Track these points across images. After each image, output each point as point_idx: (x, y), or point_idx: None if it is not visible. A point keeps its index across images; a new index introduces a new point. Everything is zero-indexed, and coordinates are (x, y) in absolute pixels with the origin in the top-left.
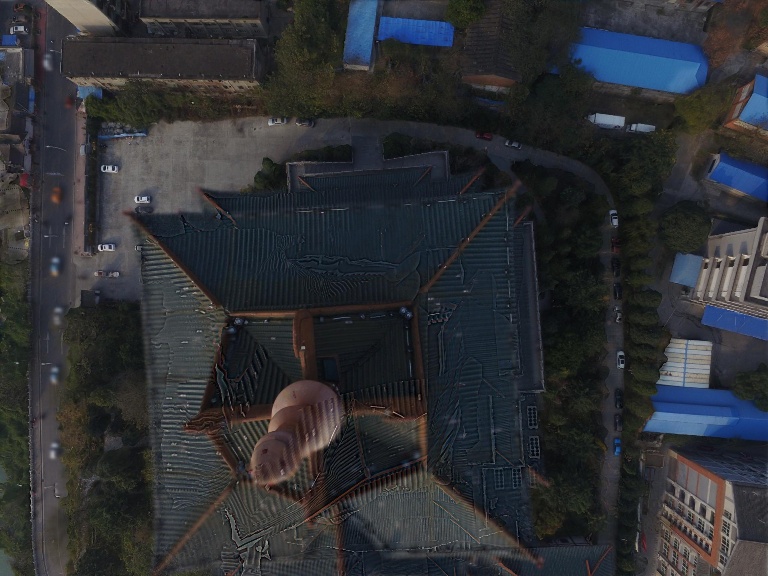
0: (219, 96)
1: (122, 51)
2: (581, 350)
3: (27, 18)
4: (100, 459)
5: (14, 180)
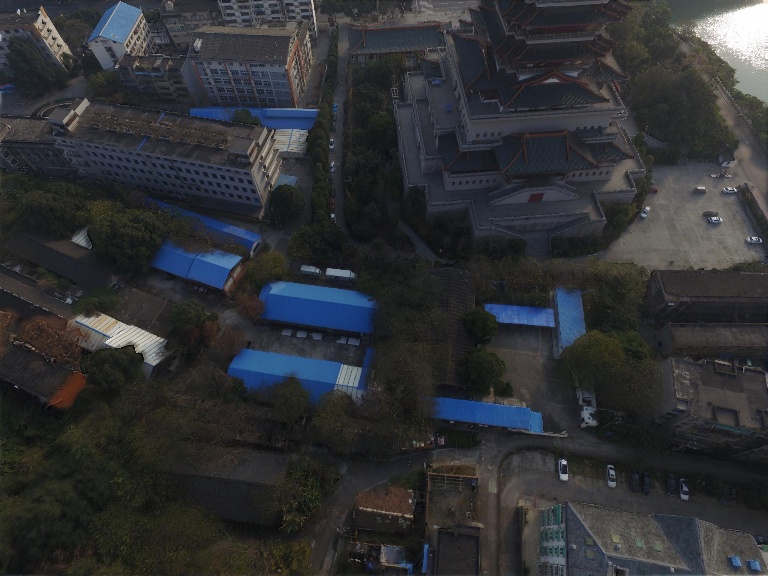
0: None
1: None
2: (372, 121)
3: None
4: None
5: None
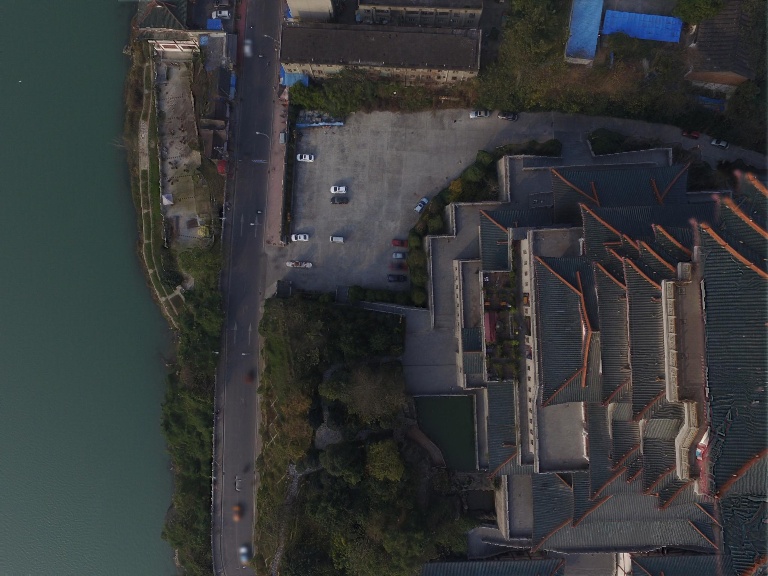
0: (423, 87)
1: (343, 38)
2: None
3: (230, 3)
4: (327, 452)
5: (200, 167)
